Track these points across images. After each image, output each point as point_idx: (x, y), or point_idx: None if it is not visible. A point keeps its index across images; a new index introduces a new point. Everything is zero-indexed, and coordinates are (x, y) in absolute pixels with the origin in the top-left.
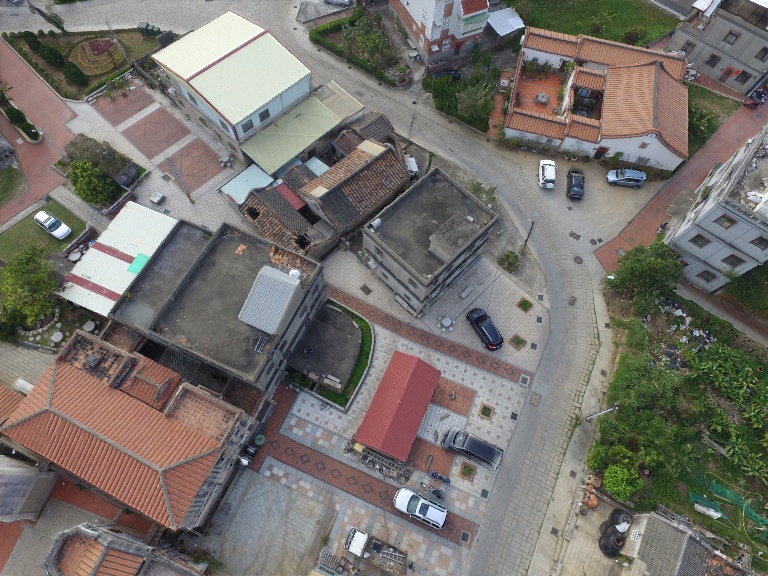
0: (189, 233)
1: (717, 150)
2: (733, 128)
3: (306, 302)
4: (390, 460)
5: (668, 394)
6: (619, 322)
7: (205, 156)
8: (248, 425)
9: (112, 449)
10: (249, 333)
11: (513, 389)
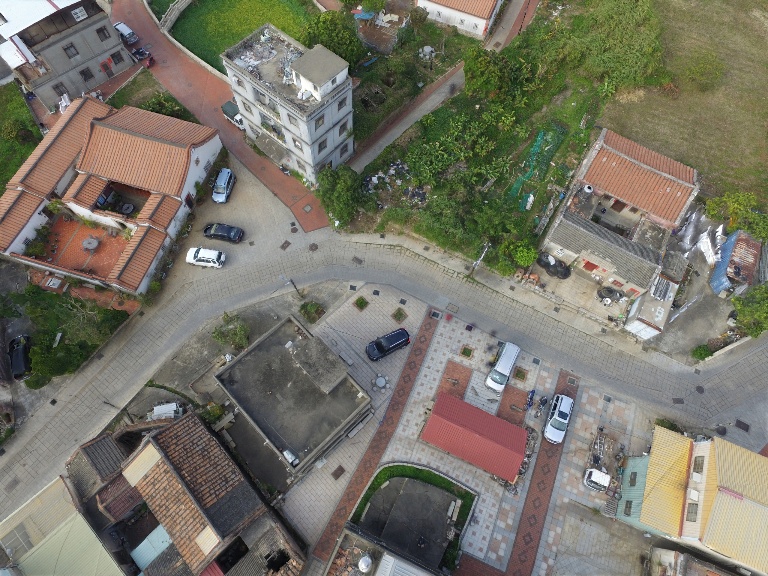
0: None
1: (199, 104)
2: (175, 85)
3: None
4: None
5: (453, 205)
6: (380, 227)
7: None
8: None
9: None
10: None
11: (444, 326)
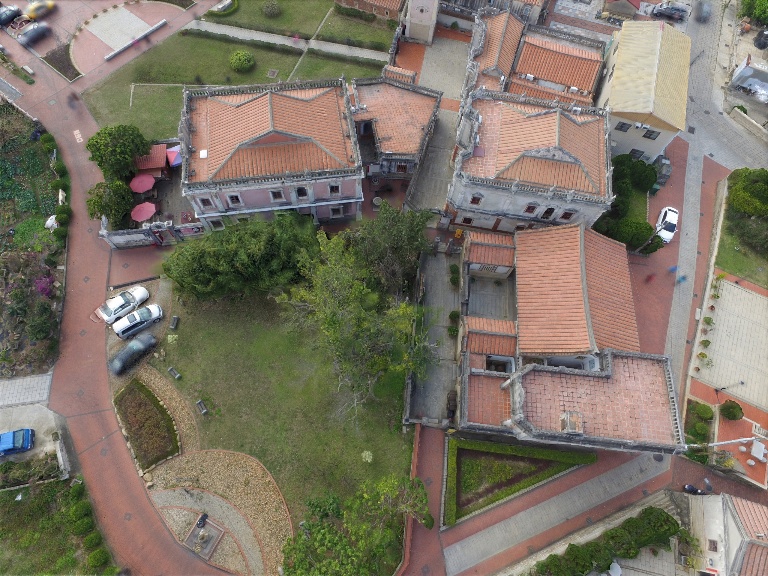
0: None
1: None
2: None
3: None
4: None
5: None
6: None
7: None
8: None
9: None
10: None
11: None
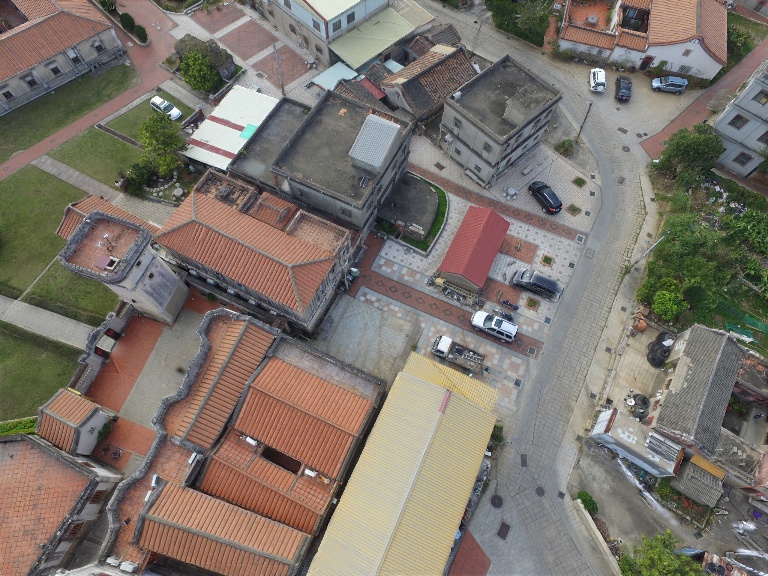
0: (290, 109)
1: (752, 66)
2: (767, 49)
3: (398, 156)
4: (467, 291)
5: (708, 243)
6: (663, 196)
7: (293, 59)
8: (349, 253)
9: (248, 251)
10: (354, 173)
11: (570, 245)
